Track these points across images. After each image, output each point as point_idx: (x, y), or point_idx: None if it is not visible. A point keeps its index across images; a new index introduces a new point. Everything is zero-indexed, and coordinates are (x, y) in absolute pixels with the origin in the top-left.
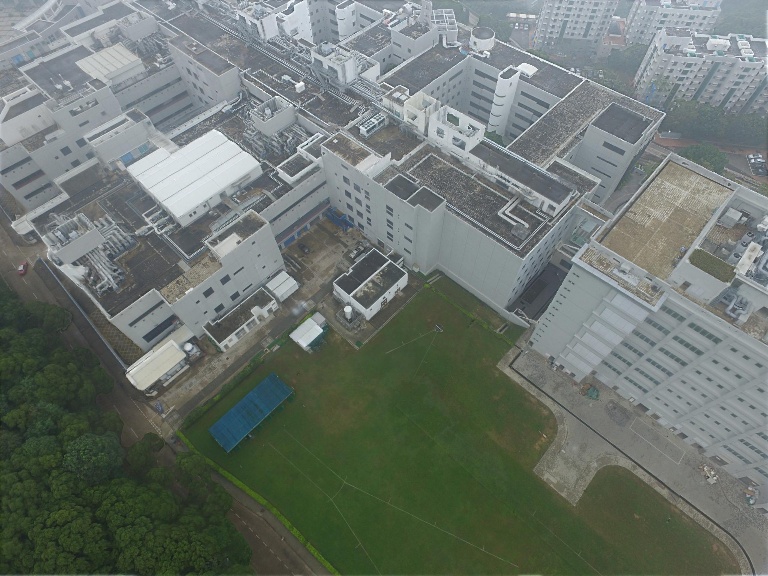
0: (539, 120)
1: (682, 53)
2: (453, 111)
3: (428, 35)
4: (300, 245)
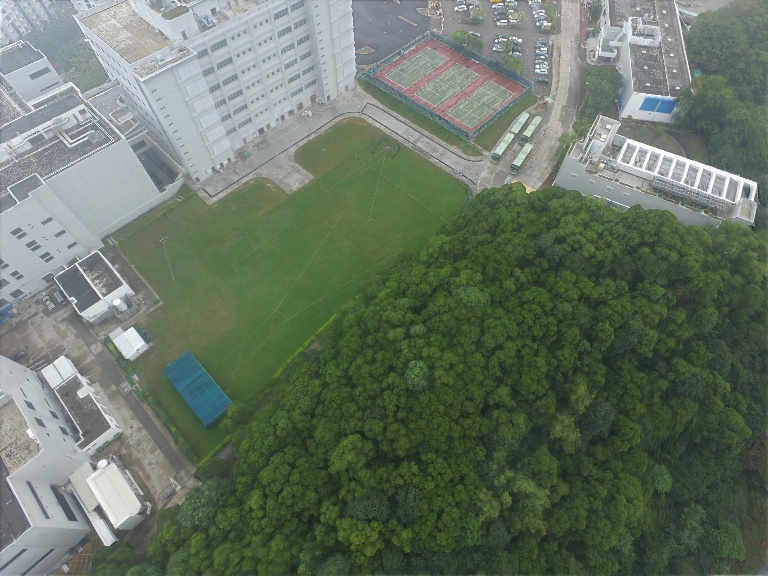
0: None
1: None
2: None
3: None
4: None
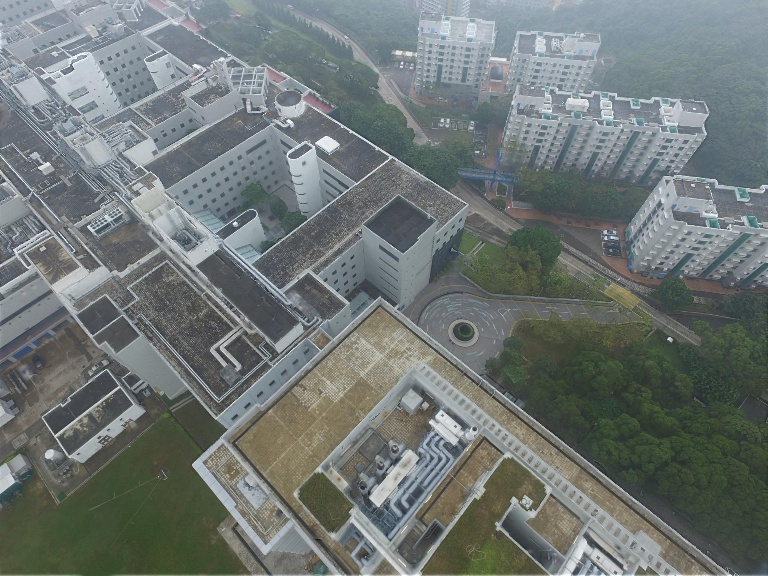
0: (321, 211)
1: (537, 114)
2: (185, 214)
3: (224, 100)
4: (34, 358)
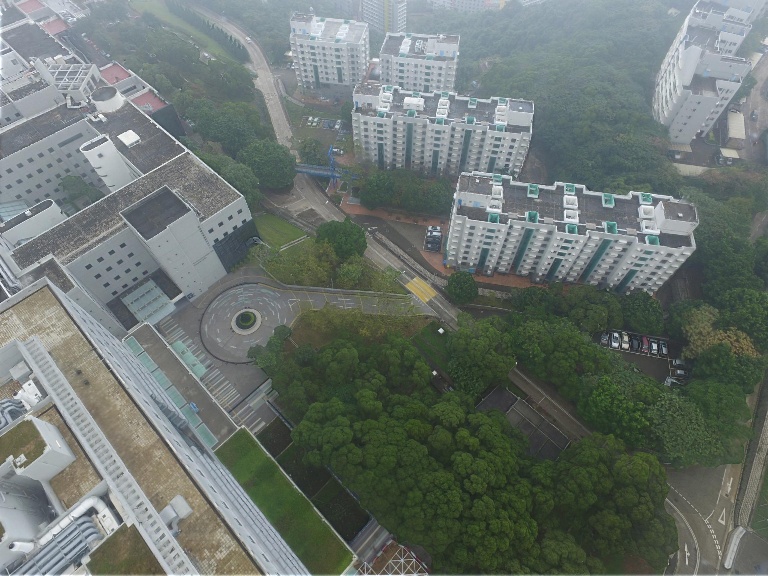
0: (101, 201)
1: (374, 112)
2: None
3: (39, 95)
4: None
